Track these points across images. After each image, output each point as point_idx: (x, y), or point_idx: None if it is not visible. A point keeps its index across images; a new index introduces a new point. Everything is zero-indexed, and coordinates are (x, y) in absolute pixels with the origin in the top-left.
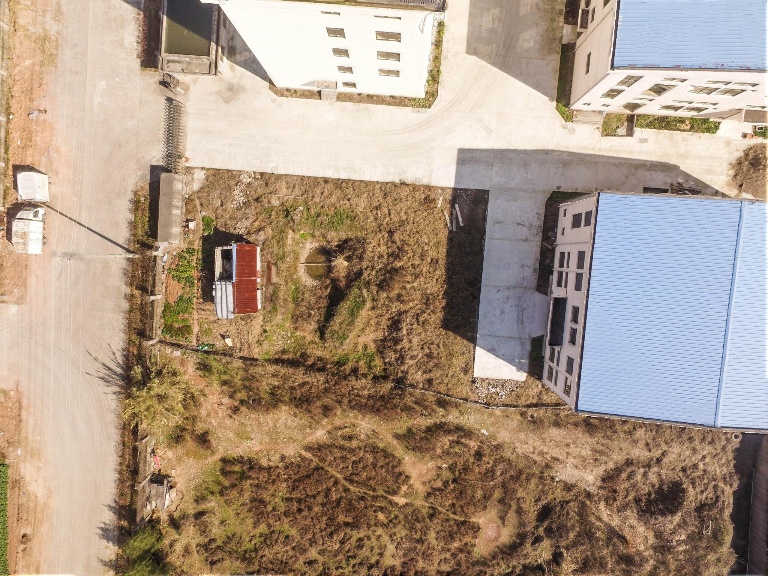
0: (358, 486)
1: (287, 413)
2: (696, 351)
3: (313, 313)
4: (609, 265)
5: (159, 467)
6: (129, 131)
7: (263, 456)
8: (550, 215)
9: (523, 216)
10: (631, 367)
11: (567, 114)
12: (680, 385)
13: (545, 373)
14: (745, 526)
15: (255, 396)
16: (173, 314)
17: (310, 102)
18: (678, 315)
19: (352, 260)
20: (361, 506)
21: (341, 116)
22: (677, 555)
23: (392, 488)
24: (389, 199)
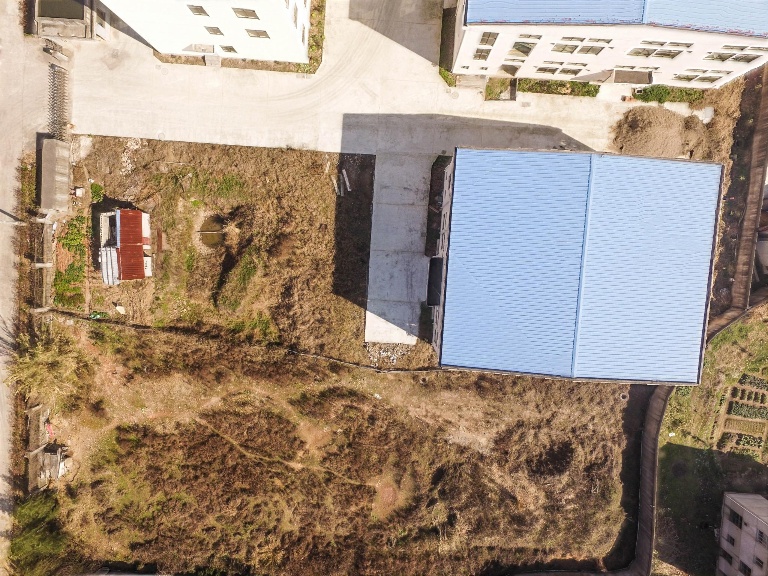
0: (253, 452)
1: (181, 380)
2: (552, 303)
3: (207, 281)
4: (467, 220)
5: (55, 437)
6: (14, 98)
7: (158, 424)
8: (436, 179)
9: (410, 180)
10: (491, 320)
11: (450, 78)
12: (537, 337)
13: (433, 336)
14: (635, 485)
15: (147, 363)
16: (64, 283)
17: (195, 68)
18: (534, 268)
19: (243, 227)
20: (257, 472)
21: (226, 82)
22: (566, 514)
23: (288, 454)
24: (276, 165)
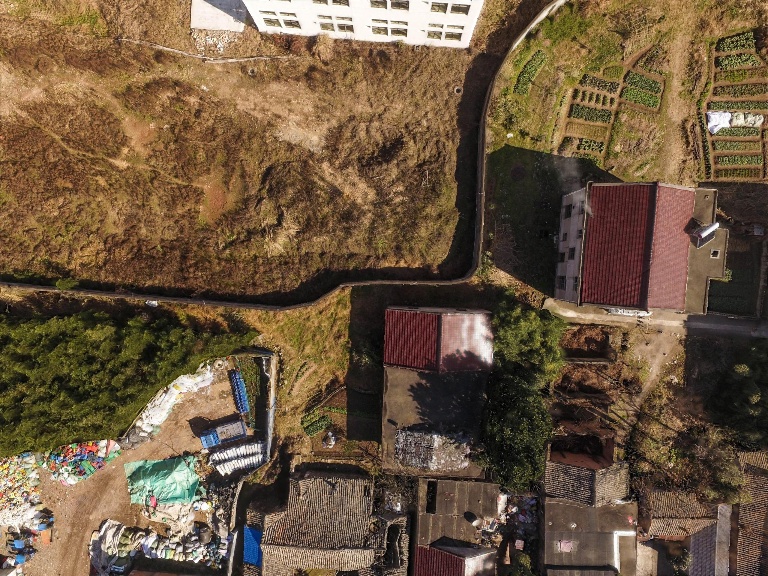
0: (75, 146)
1: (1, 69)
2: None
3: None
4: None
5: None
6: None
7: None
8: None
9: None
10: None
11: None
12: None
13: None
14: (472, 188)
15: None
16: None
17: None
18: None
19: None
20: (79, 168)
21: None
22: (395, 208)
23: (112, 150)
24: None
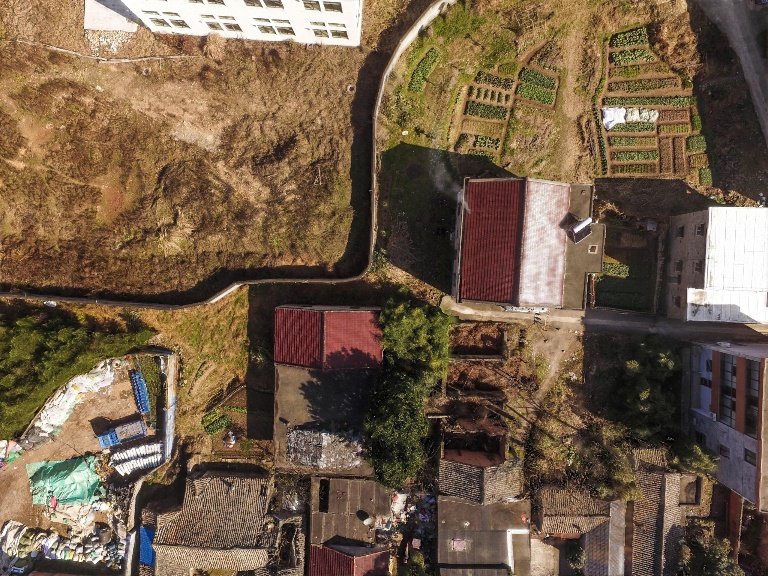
0: None
1: None
2: None
3: None
4: None
5: None
6: None
7: None
8: None
9: None
10: None
11: None
12: None
13: None
14: (367, 186)
15: None
16: None
17: None
18: None
19: None
20: None
21: None
22: (287, 206)
23: (9, 151)
24: None
